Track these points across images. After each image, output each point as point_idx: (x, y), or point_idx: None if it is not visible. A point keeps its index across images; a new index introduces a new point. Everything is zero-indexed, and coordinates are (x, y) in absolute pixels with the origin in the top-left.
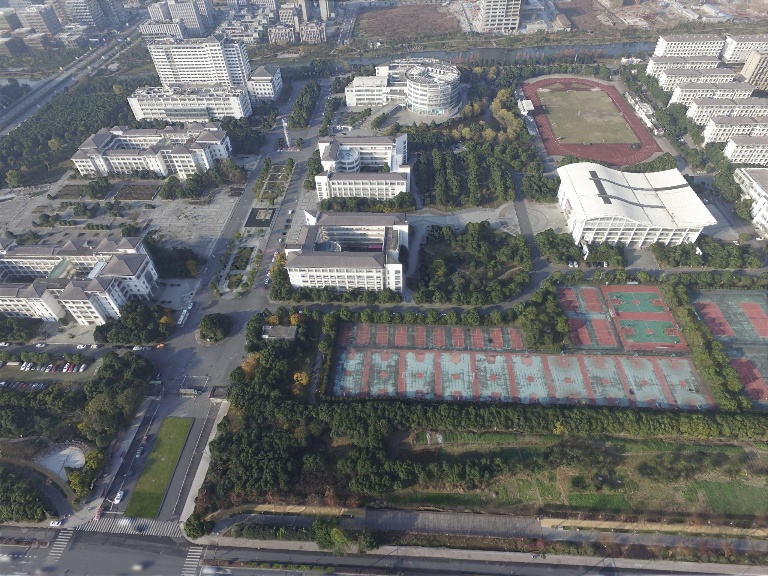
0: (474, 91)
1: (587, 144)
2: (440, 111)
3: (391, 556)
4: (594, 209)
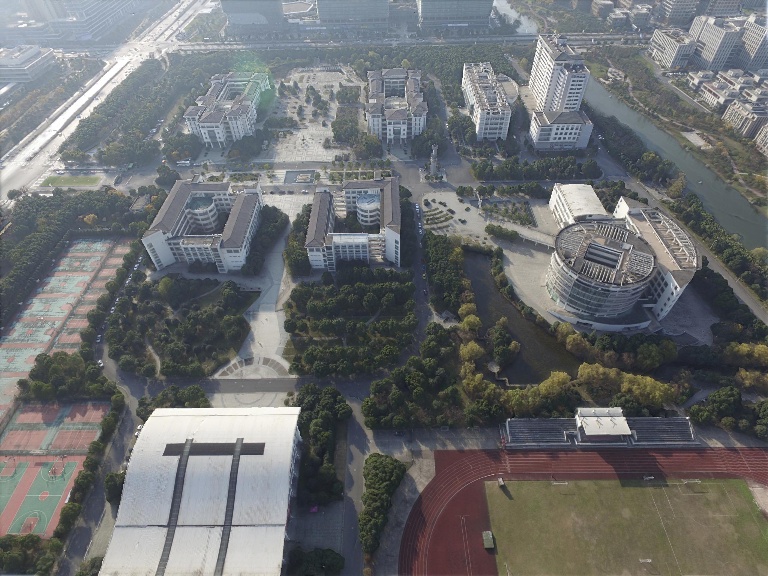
0: (642, 338)
1: (484, 539)
2: None
3: None
4: (161, 426)
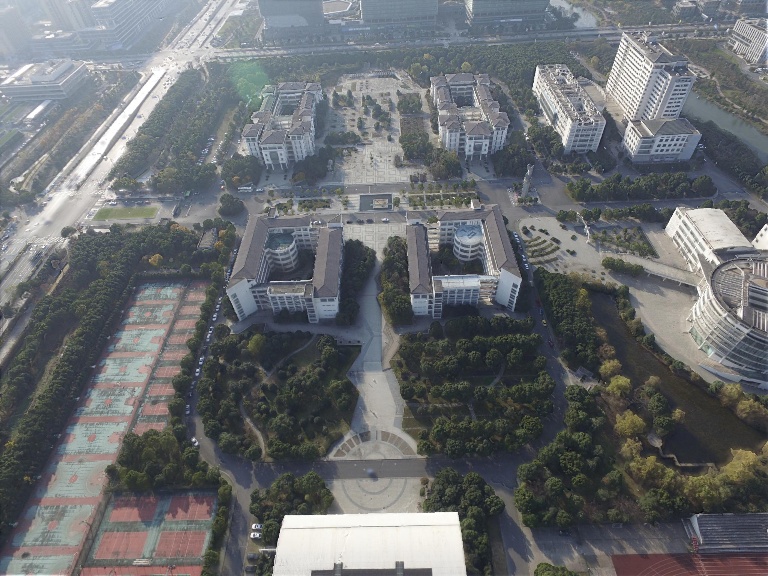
0: None
1: None
2: (710, 348)
3: (1, 328)
4: (299, 544)
